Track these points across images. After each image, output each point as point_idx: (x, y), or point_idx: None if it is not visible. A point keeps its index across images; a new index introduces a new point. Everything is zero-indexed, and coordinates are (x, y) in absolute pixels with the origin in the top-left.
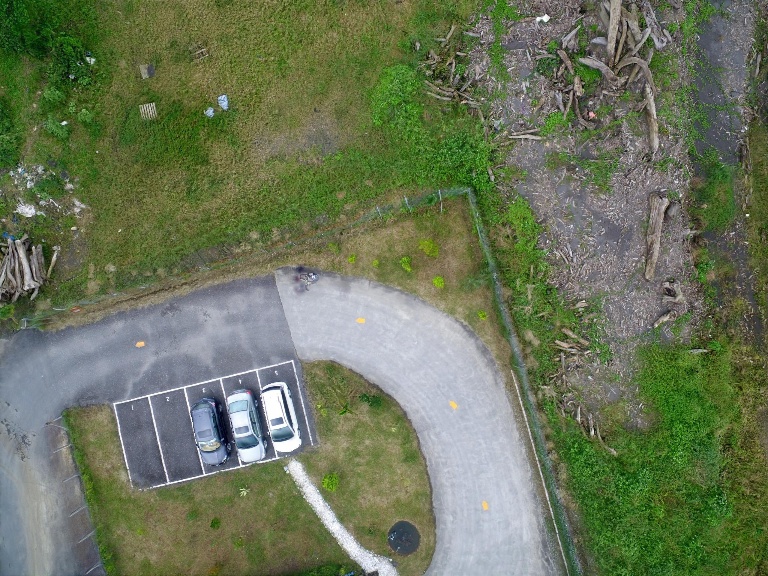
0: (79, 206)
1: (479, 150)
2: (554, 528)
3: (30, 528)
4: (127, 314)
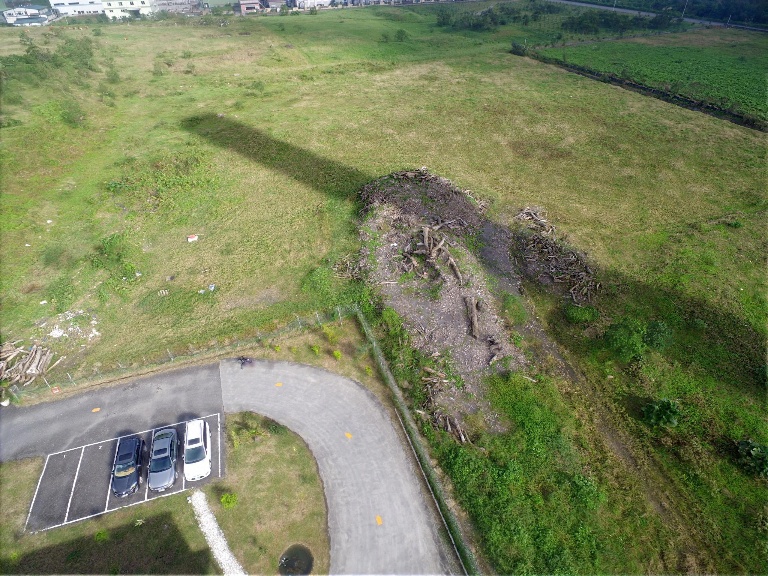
0: (94, 333)
1: None
2: (450, 540)
3: None
4: (96, 391)
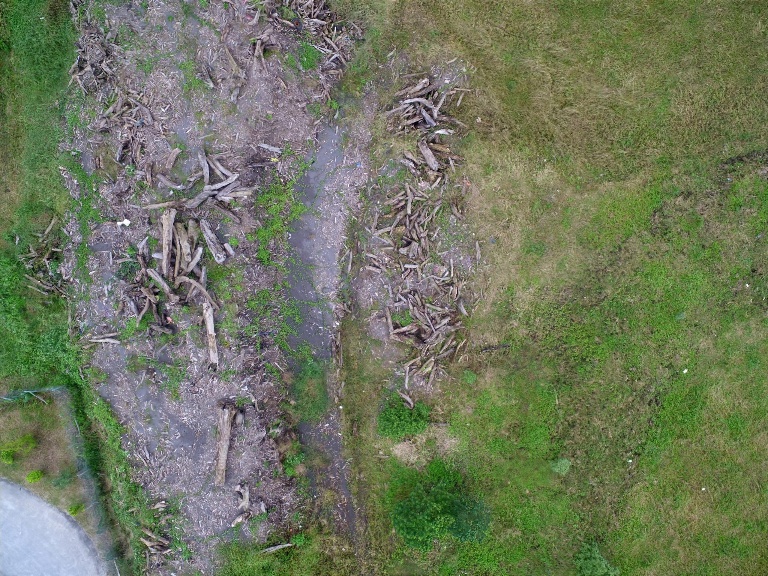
0: None
1: (68, 349)
2: None
3: None
4: None
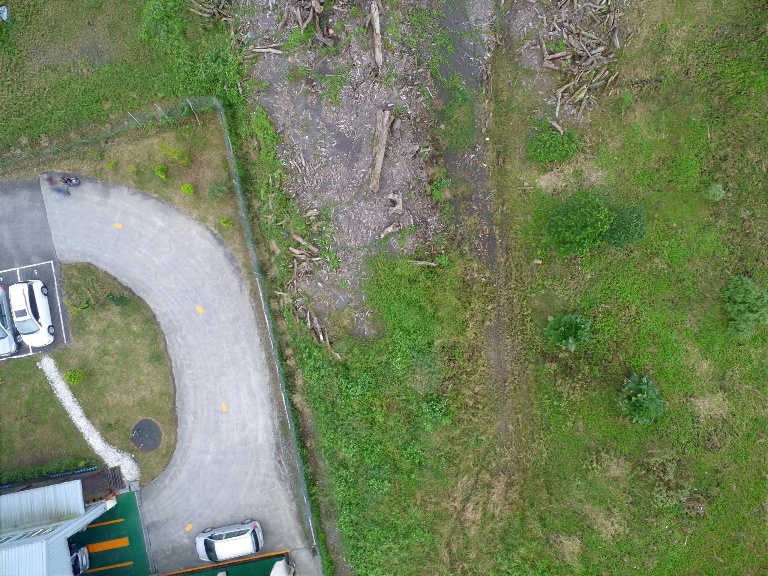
0: None
1: (229, 63)
2: (289, 432)
3: None
4: None
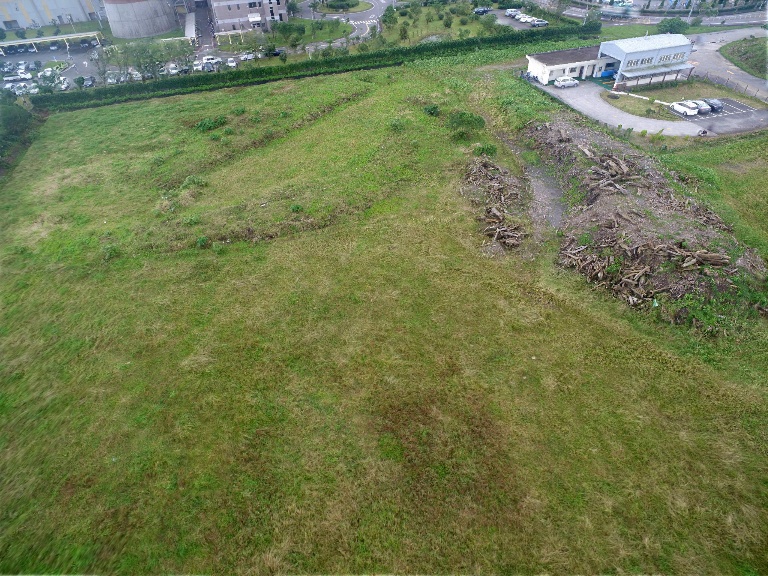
0: None
1: None
2: None
3: None
4: None
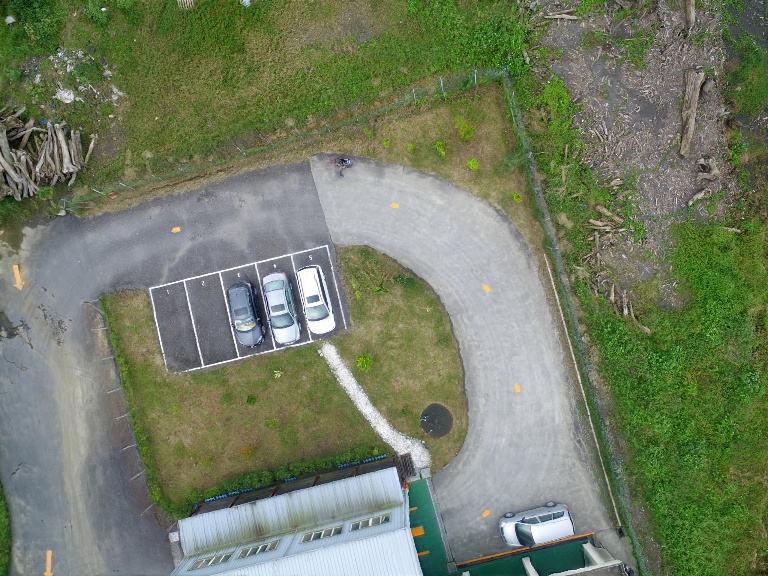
0: (117, 93)
1: (514, 32)
2: (586, 411)
3: (66, 411)
4: (163, 200)
